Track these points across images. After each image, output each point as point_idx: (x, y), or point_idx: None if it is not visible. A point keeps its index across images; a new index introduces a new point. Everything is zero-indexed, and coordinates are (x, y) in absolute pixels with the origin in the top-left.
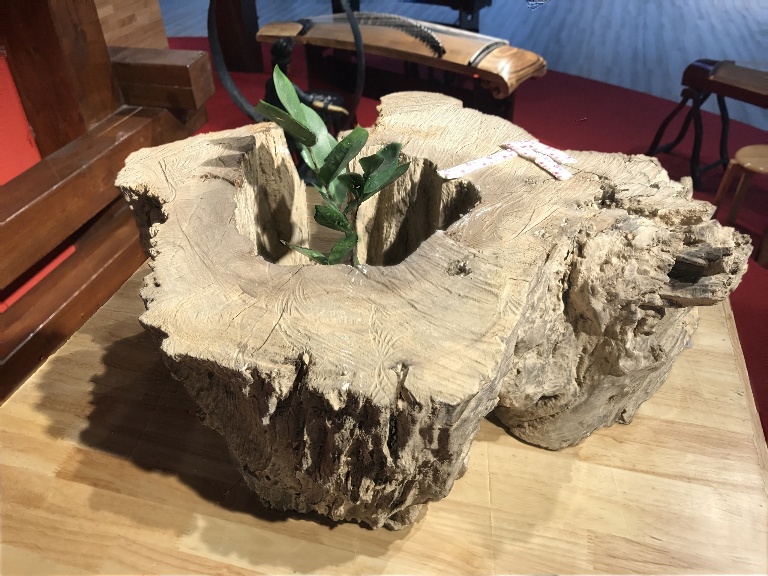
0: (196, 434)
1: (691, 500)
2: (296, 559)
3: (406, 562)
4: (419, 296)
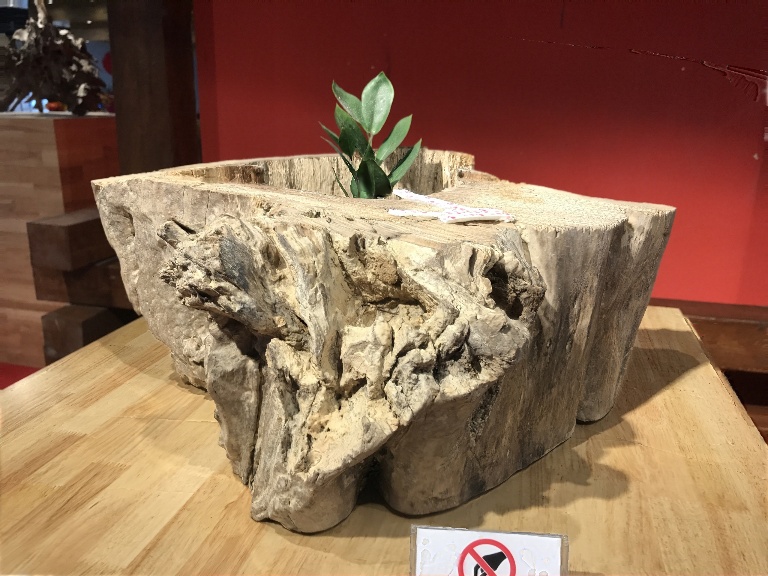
0: None
1: (120, 543)
2: None
3: None
4: None
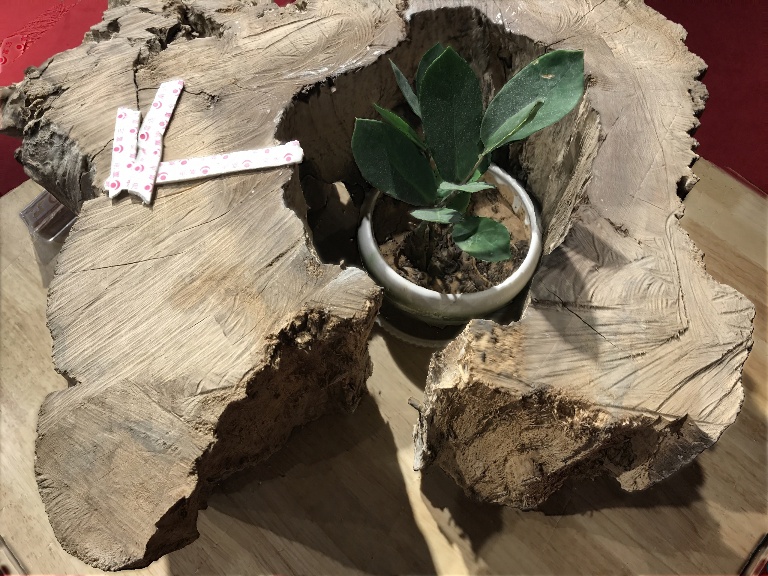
0: None
1: None
2: None
3: None
4: None
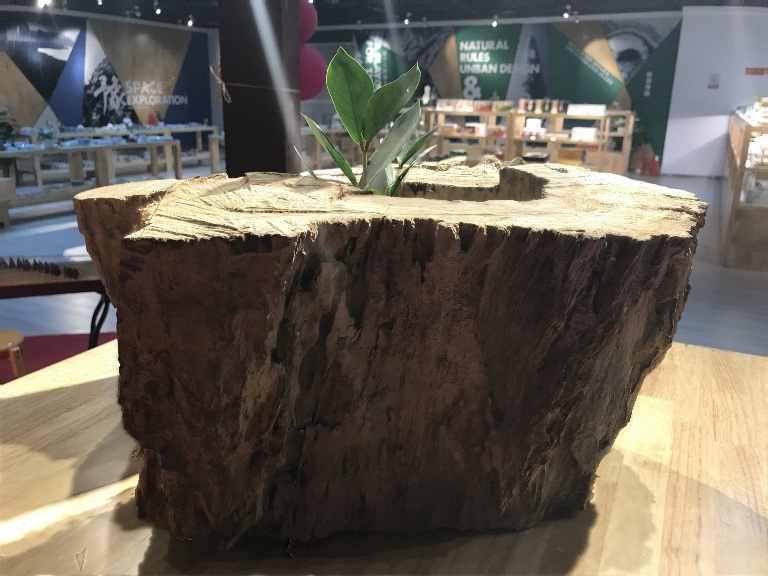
0: None
1: None
2: (640, 500)
3: (624, 441)
4: (589, 181)
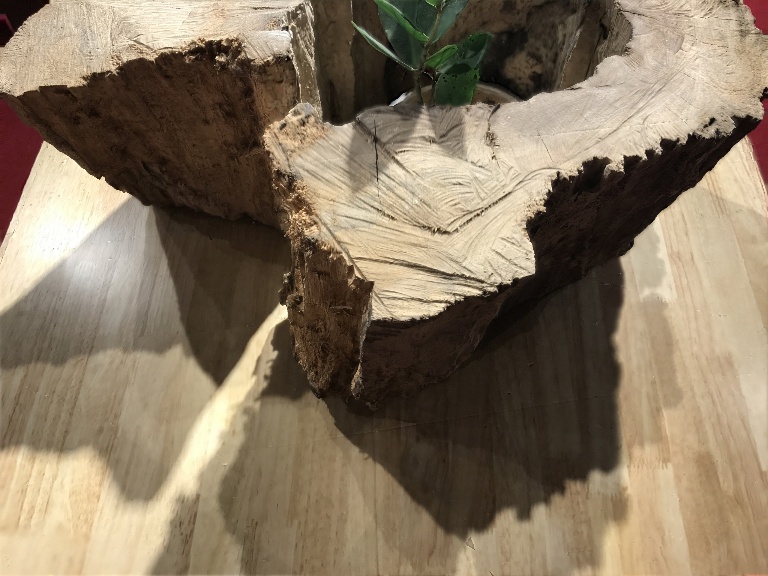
0: (557, 342)
1: None
2: None
3: None
4: None
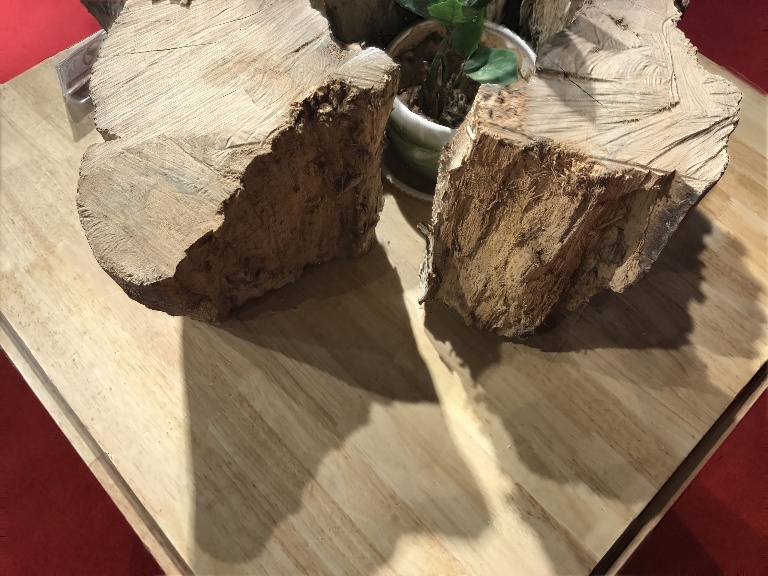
0: None
1: None
2: None
3: None
4: None
